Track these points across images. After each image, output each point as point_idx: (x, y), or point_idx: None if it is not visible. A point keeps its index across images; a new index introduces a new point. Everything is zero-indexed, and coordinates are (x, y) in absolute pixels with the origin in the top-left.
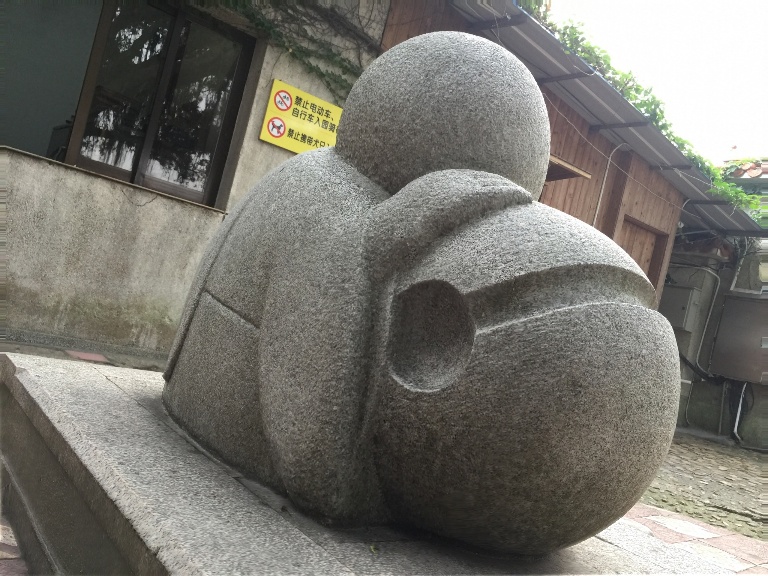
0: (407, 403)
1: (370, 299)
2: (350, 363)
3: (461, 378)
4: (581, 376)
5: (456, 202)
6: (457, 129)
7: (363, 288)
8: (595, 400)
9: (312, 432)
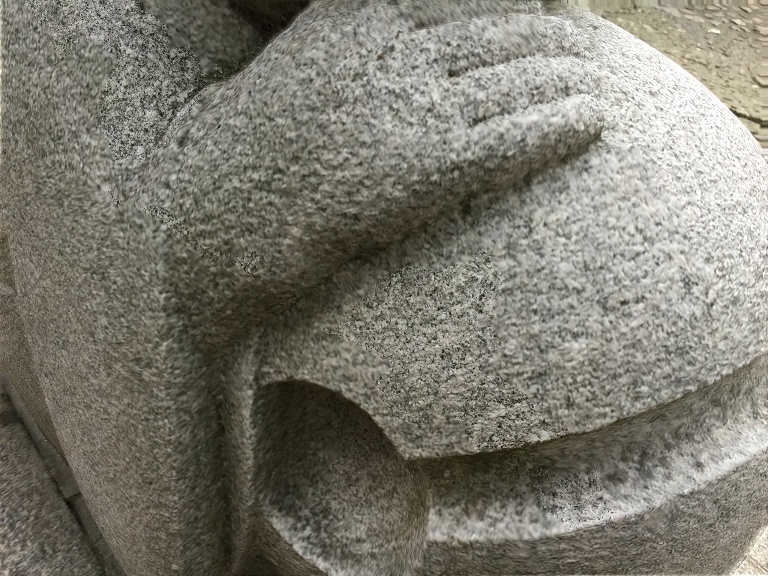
0: (301, 568)
1: (206, 386)
2: (185, 511)
3: None
4: None
5: (392, 199)
6: None
7: (184, 378)
8: None
9: None
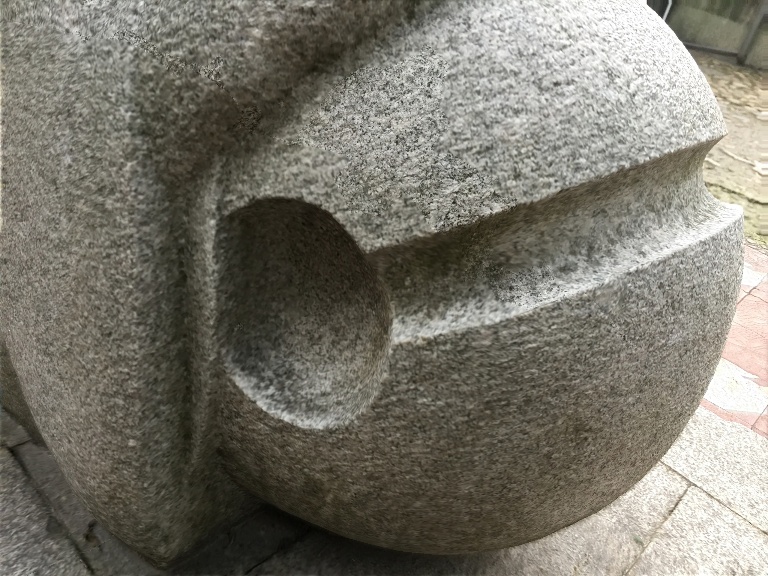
0: (266, 431)
1: (168, 223)
2: (145, 366)
3: (363, 421)
4: (593, 415)
5: None
6: None
7: (147, 207)
8: (610, 444)
9: (101, 469)
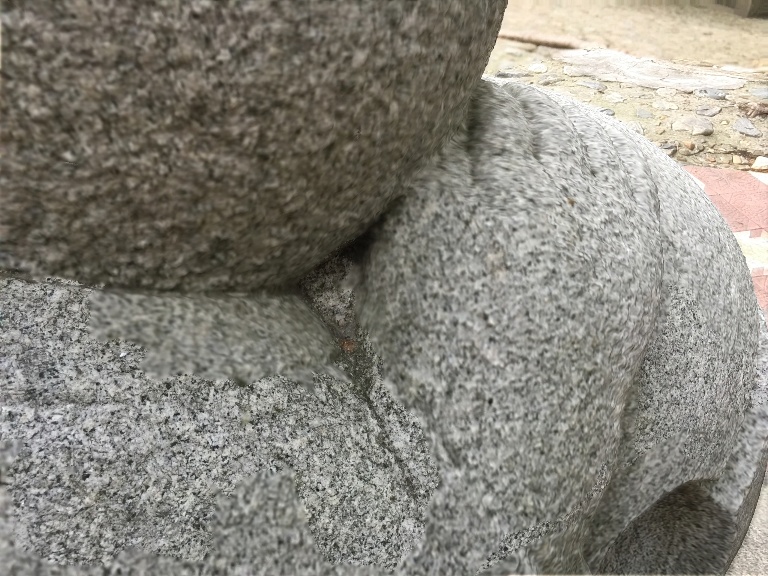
0: None
1: None
2: None
3: None
4: None
5: (658, 304)
6: (496, 2)
7: None
8: None
9: None
